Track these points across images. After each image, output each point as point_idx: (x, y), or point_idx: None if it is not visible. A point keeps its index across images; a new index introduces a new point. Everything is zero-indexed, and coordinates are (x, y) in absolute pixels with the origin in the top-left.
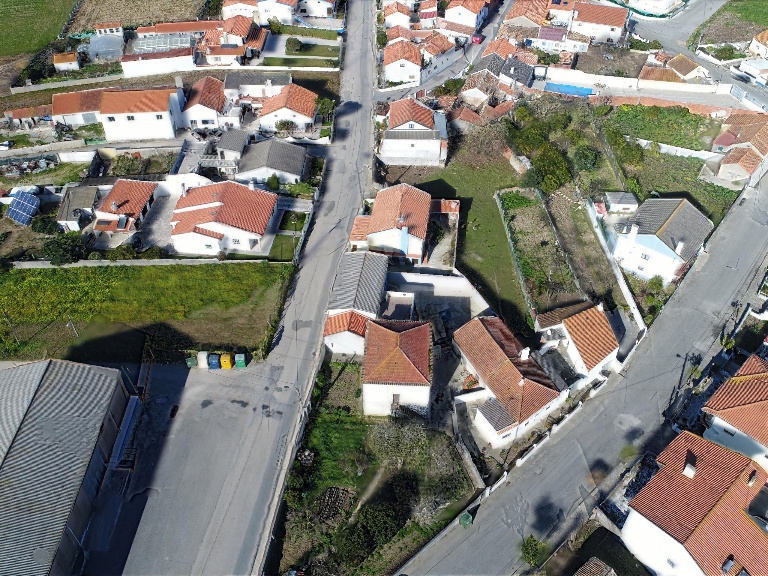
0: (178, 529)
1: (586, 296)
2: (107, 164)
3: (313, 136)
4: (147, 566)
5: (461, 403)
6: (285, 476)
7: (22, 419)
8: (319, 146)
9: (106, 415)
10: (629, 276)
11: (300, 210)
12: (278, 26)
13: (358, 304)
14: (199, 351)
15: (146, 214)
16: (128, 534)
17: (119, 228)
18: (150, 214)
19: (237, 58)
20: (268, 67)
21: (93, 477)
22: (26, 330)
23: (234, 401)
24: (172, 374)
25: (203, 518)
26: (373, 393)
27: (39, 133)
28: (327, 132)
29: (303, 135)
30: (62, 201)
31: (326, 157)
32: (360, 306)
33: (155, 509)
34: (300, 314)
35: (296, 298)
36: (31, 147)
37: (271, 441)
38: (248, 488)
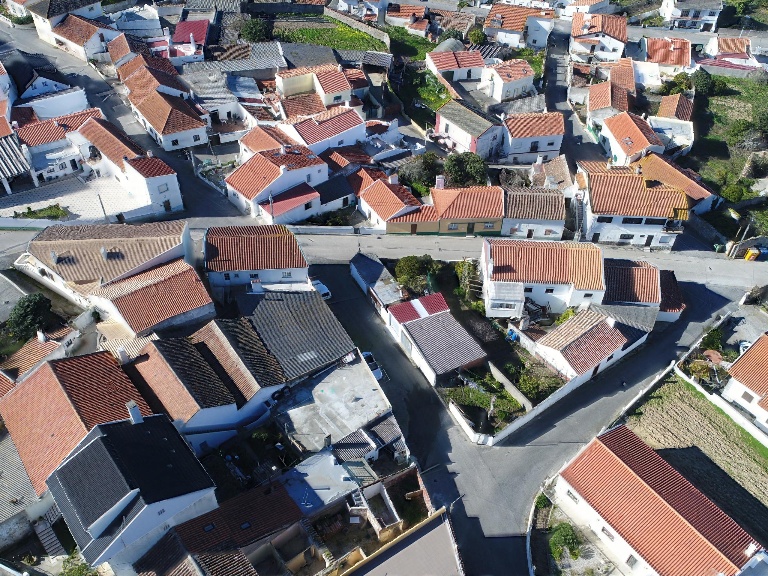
0: None
1: (619, 6)
2: None
3: None
4: None
5: None
6: None
7: None
8: None
9: None
10: (657, 17)
11: None
12: None
13: None
14: None
15: None
16: None
17: None
18: None
19: None
20: None
21: None
22: None
23: None
24: None
25: None
26: None
27: None
28: None
29: None
30: None
31: None
32: None
33: None
34: None
35: None
36: None
37: None
38: None
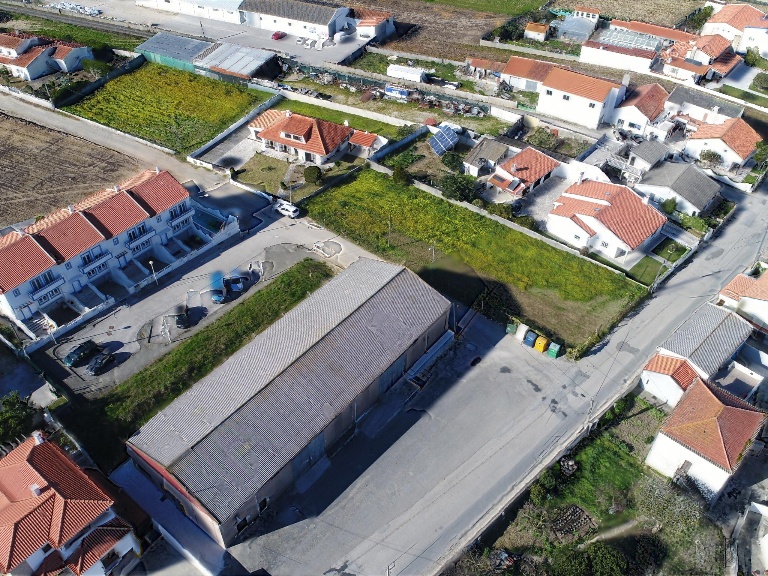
0: (431, 456)
1: None
2: (526, 130)
3: (735, 178)
4: (394, 469)
5: (756, 512)
6: (541, 470)
7: (364, 302)
8: (736, 190)
9: (423, 333)
10: None
11: (683, 243)
12: (755, 57)
13: (695, 357)
14: (522, 323)
15: (537, 186)
16: (393, 436)
17: (509, 188)
18: (540, 187)
19: (695, 76)
20: (723, 94)
21: (390, 376)
22: (399, 238)
23: (530, 381)
24: (490, 330)
25: (455, 461)
26: (665, 447)
27: (485, 84)
28: (753, 179)
29: (725, 173)
30: (475, 147)
31: (738, 203)
32: (696, 360)
33: (422, 429)
34: (631, 338)
35: (635, 322)
36: (473, 94)
37: (544, 433)
38: (504, 460)
